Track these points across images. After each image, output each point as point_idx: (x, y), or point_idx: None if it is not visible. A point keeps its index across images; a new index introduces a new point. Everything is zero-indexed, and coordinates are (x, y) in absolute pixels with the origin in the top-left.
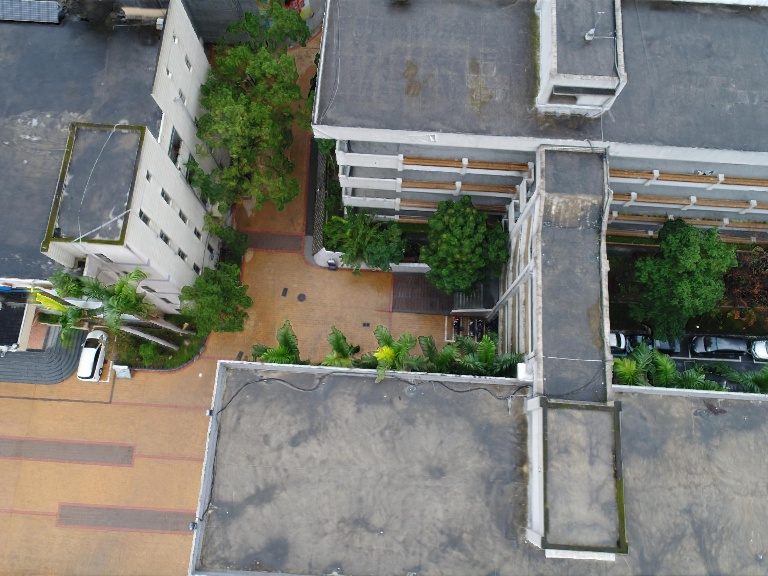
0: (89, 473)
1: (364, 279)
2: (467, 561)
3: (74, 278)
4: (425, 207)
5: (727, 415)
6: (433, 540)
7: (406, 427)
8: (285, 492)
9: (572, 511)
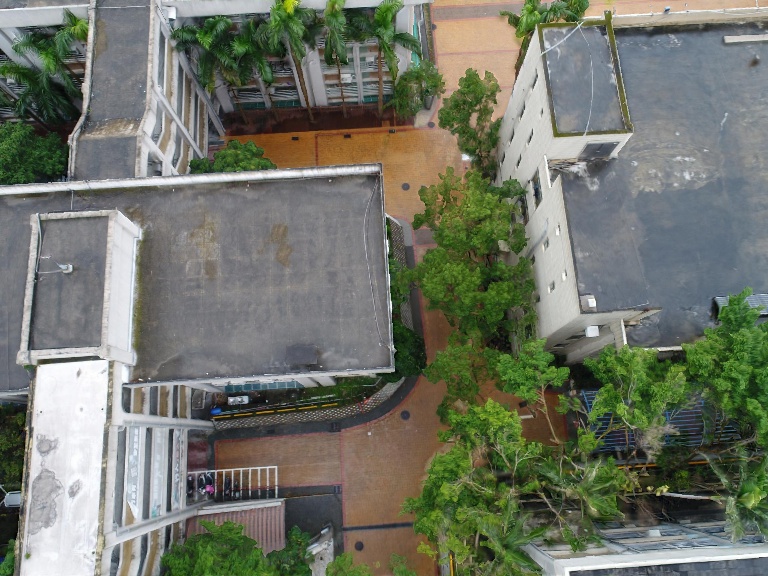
0: None
1: None
2: None
3: None
4: None
5: None
6: None
7: None
8: None
9: None
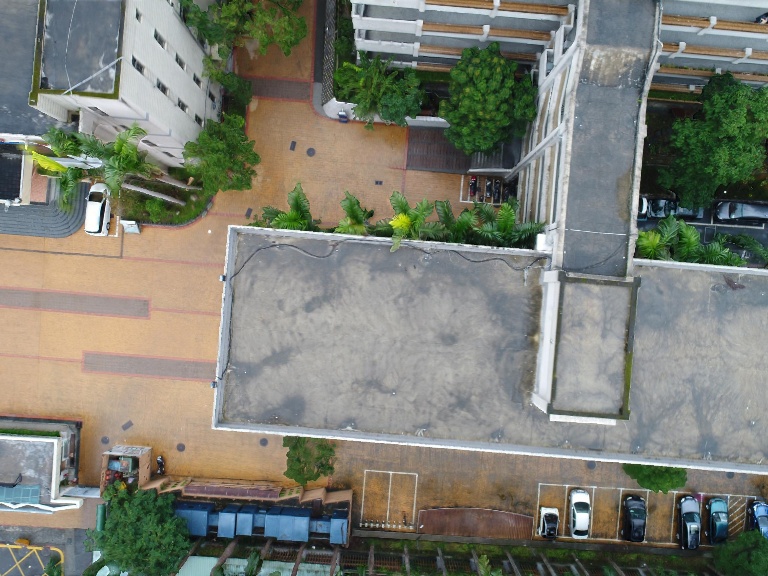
0: (108, 324)
1: (377, 133)
2: (474, 420)
3: (69, 134)
4: (447, 54)
5: (745, 290)
6: (443, 401)
7: (420, 296)
8: (300, 355)
9: (580, 381)
